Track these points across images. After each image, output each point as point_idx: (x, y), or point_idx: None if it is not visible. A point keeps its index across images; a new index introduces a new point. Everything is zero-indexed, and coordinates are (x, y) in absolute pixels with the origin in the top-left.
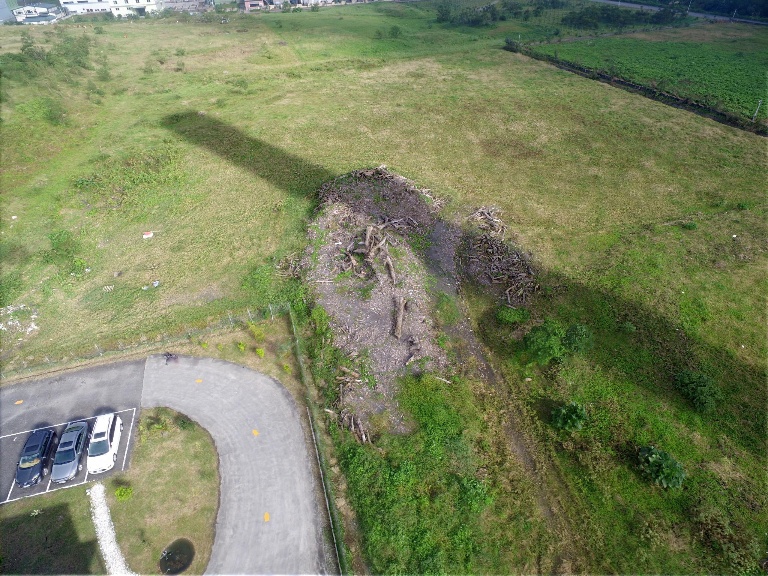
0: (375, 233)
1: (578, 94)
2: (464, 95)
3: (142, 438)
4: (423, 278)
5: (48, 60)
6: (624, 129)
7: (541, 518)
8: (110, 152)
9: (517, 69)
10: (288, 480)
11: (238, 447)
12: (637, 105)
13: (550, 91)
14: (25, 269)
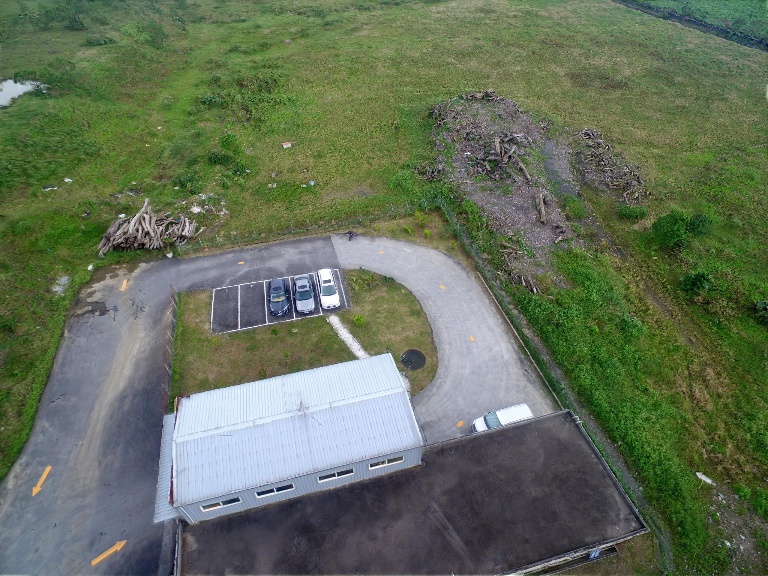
0: None
1: (652, 32)
2: (539, 31)
3: (356, 287)
4: (547, 183)
5: None
6: (703, 66)
7: (684, 344)
8: (217, 75)
9: (585, 7)
10: (480, 317)
11: (432, 296)
12: (712, 44)
13: (623, 29)
14: (196, 168)
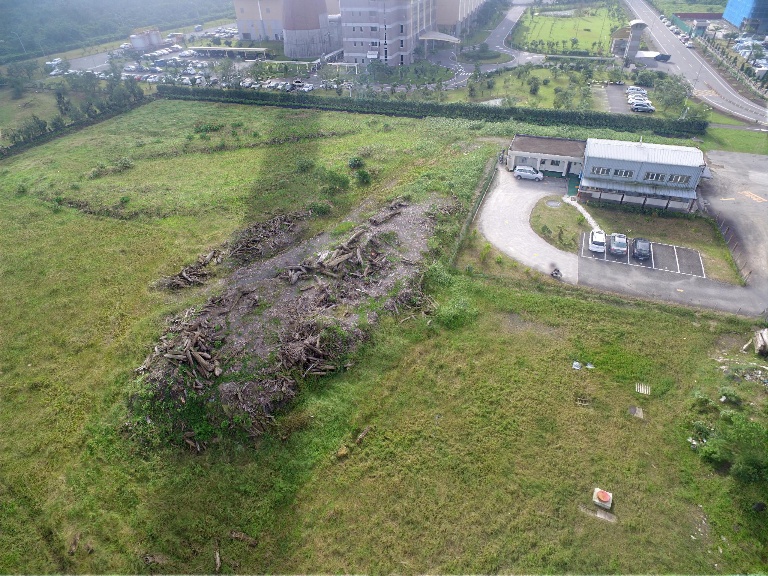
0: None
1: None
2: None
3: None
4: None
5: None
6: None
7: None
8: None
9: None
10: None
11: None
12: None
13: None
14: None
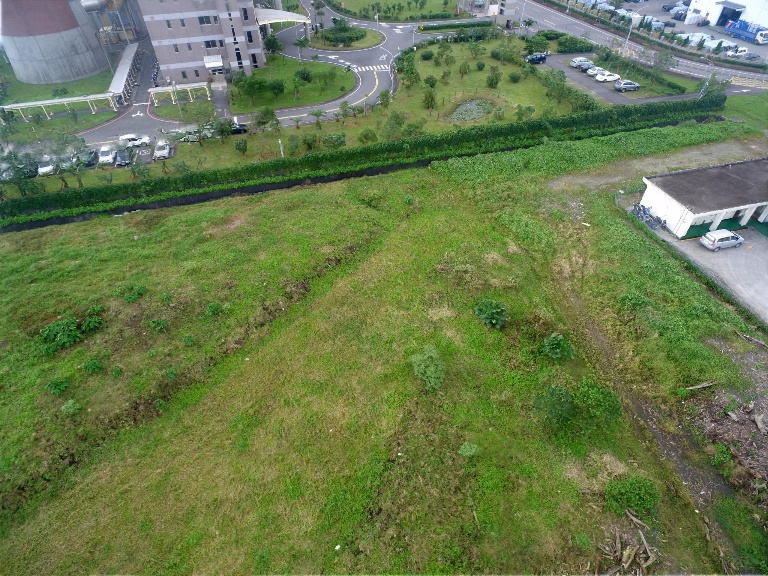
0: None
1: None
2: None
3: None
4: None
5: None
6: None
7: None
8: None
9: None
10: None
11: None
12: None
13: None
14: None
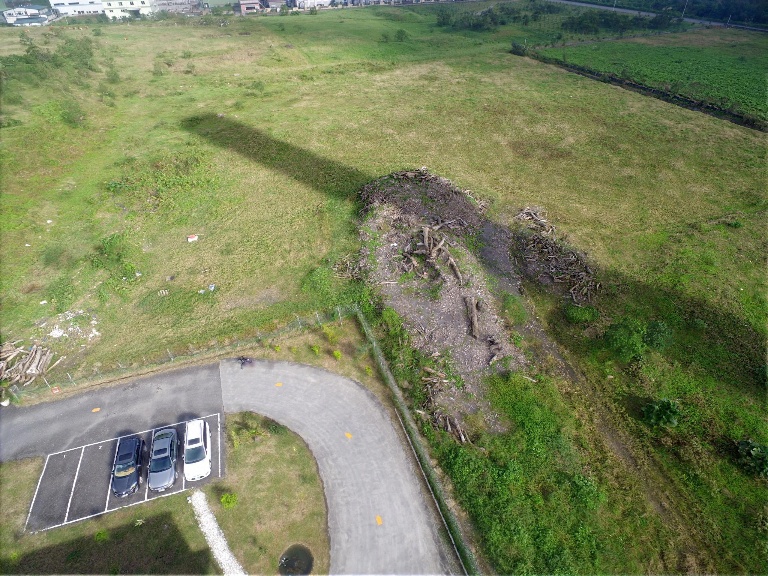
0: (431, 234)
1: (594, 97)
2: (481, 98)
3: (235, 443)
4: (484, 278)
5: (55, 62)
6: (647, 131)
7: (654, 513)
8: (135, 155)
9: (528, 72)
10: (392, 482)
11: (334, 450)
12: (654, 107)
13: (565, 94)
14: (74, 274)
